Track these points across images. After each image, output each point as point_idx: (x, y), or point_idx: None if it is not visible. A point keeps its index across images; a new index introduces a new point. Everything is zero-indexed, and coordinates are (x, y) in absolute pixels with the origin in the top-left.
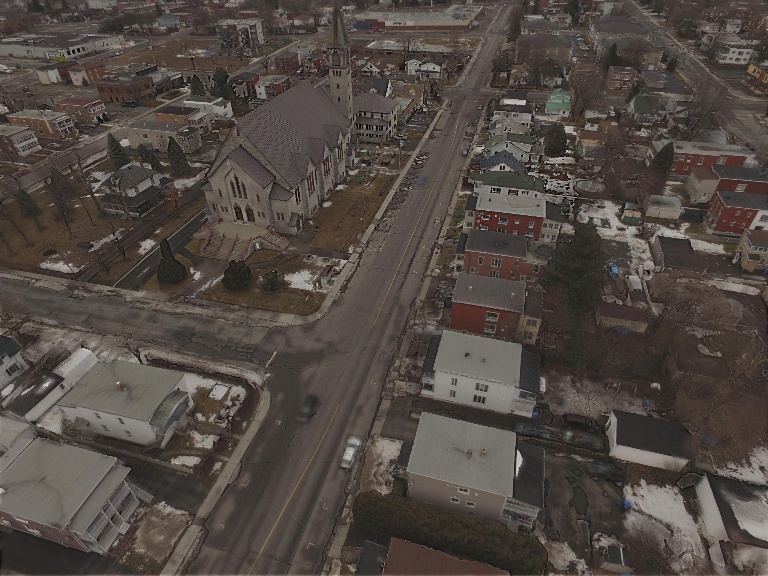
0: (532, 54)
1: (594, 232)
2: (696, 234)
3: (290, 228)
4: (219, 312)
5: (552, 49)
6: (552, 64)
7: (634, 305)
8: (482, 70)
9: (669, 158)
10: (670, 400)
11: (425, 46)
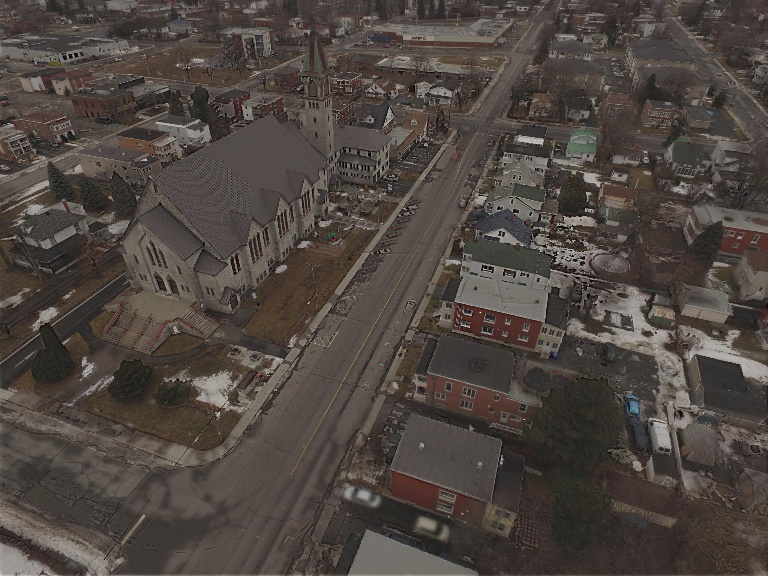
0: (558, 81)
1: (604, 390)
2: (749, 352)
3: (222, 305)
4: (94, 434)
5: (581, 76)
6: (580, 93)
7: (658, 480)
8: (501, 96)
9: (716, 242)
10: None
11: (441, 65)
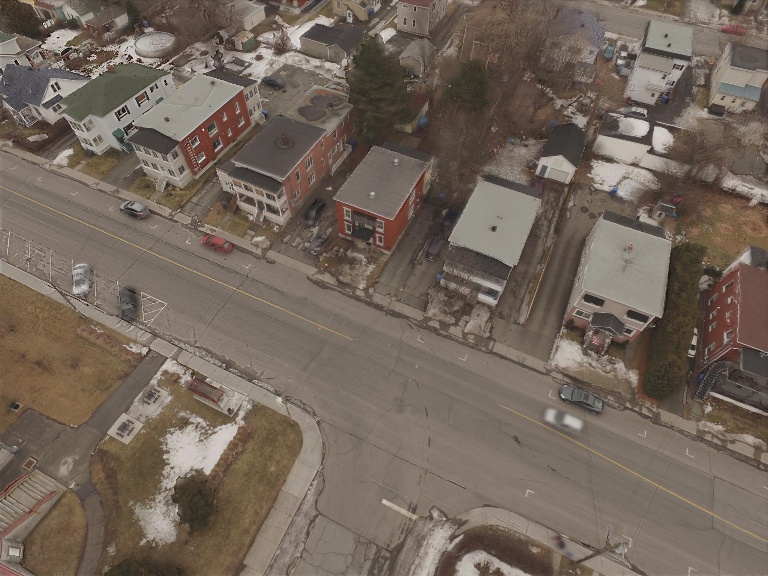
0: None
1: None
2: (301, 18)
3: None
4: None
5: None
6: None
7: None
8: None
9: None
10: (511, 127)
11: None
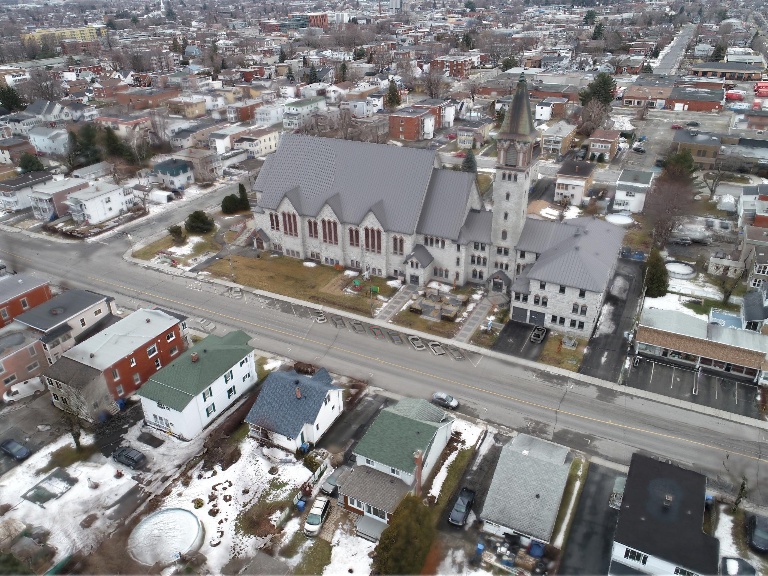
0: None
1: None
2: None
3: None
4: None
5: None
6: None
7: None
8: None
9: None
10: None
11: None
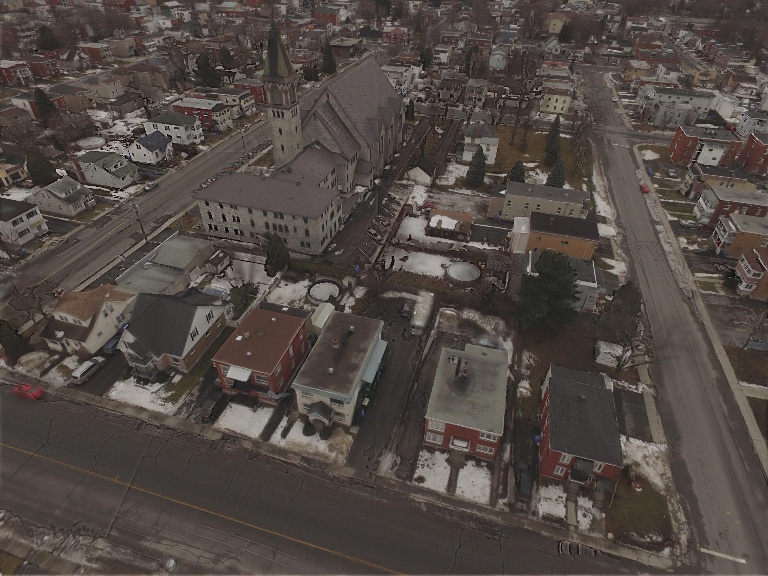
0: None
1: None
2: None
3: None
4: None
5: None
6: None
7: None
8: None
9: None
10: None
11: None
